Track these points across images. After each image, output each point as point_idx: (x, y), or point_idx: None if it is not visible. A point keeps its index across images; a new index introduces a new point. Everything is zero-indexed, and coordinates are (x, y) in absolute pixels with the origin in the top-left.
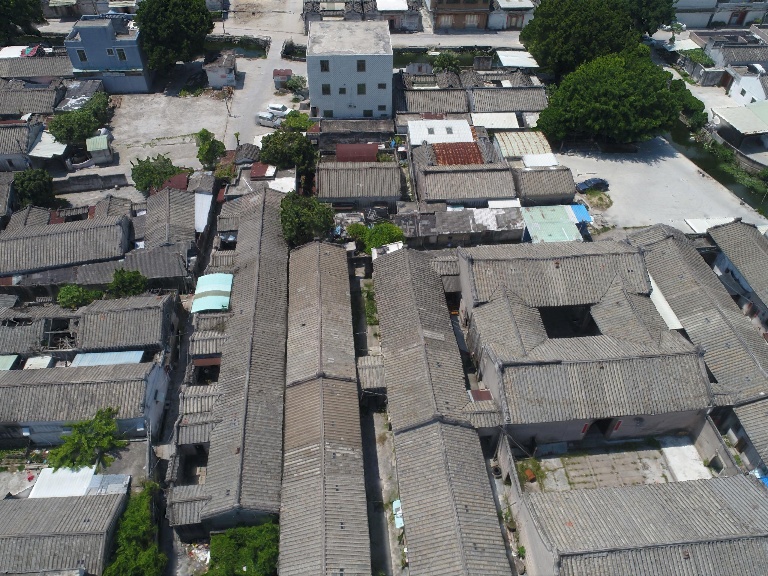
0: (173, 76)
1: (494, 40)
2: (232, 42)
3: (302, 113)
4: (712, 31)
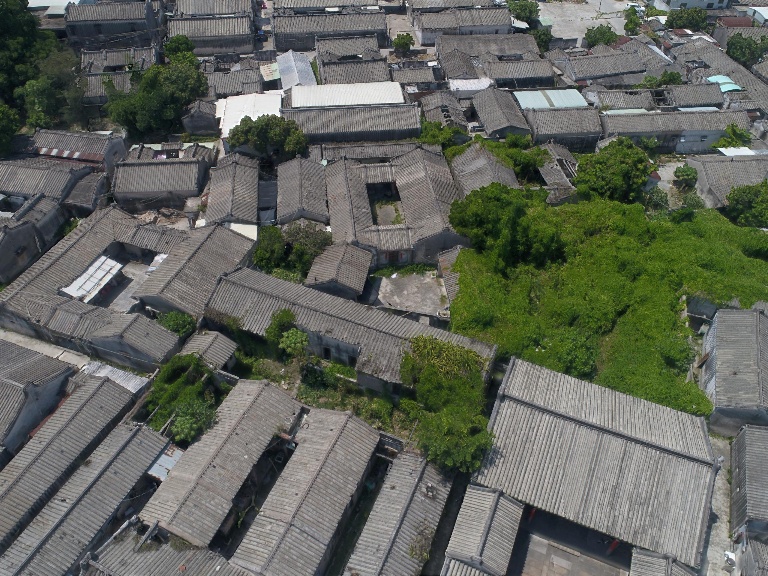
0: None
1: None
2: None
3: None
4: None
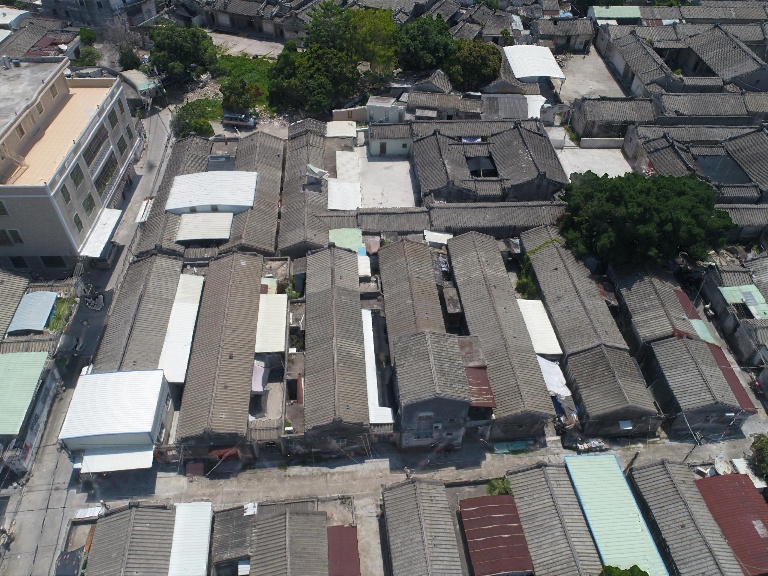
0: None
1: None
2: None
3: None
4: None
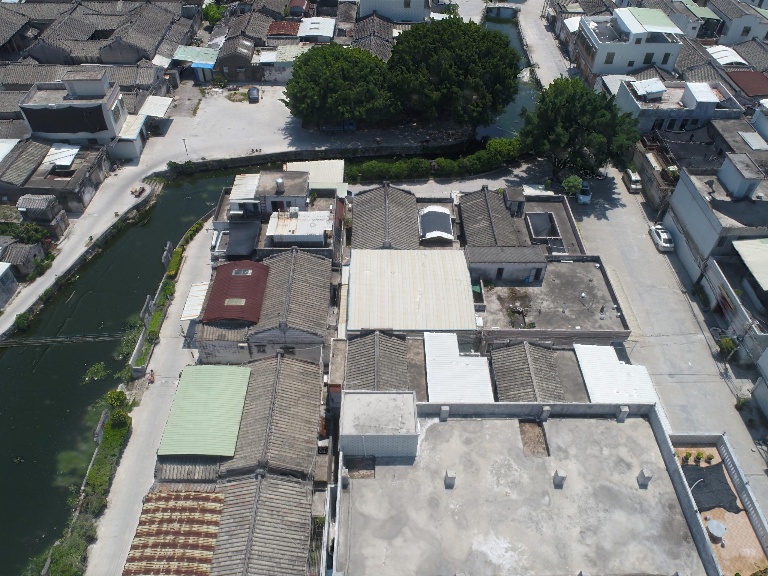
0: None
1: None
2: None
3: None
4: (572, 215)
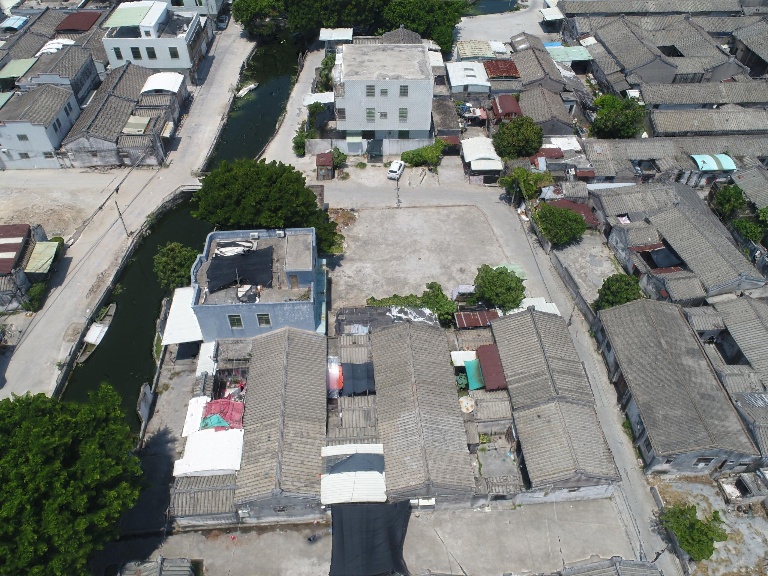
0: None
1: (231, 58)
2: (145, 237)
3: (407, 152)
4: None
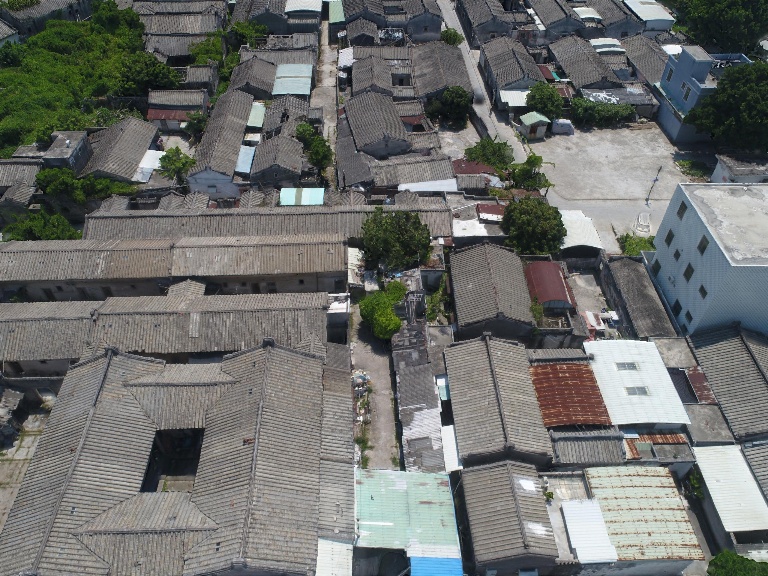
0: (722, 152)
1: None
2: None
3: None
4: None
